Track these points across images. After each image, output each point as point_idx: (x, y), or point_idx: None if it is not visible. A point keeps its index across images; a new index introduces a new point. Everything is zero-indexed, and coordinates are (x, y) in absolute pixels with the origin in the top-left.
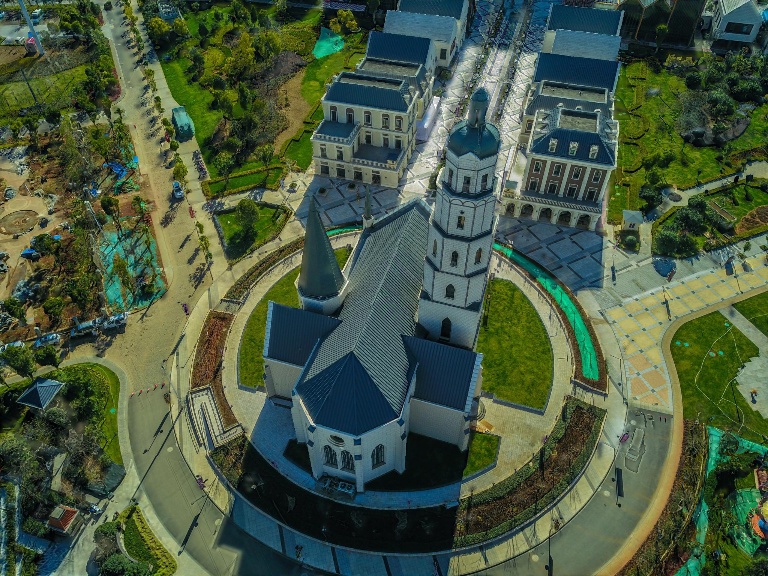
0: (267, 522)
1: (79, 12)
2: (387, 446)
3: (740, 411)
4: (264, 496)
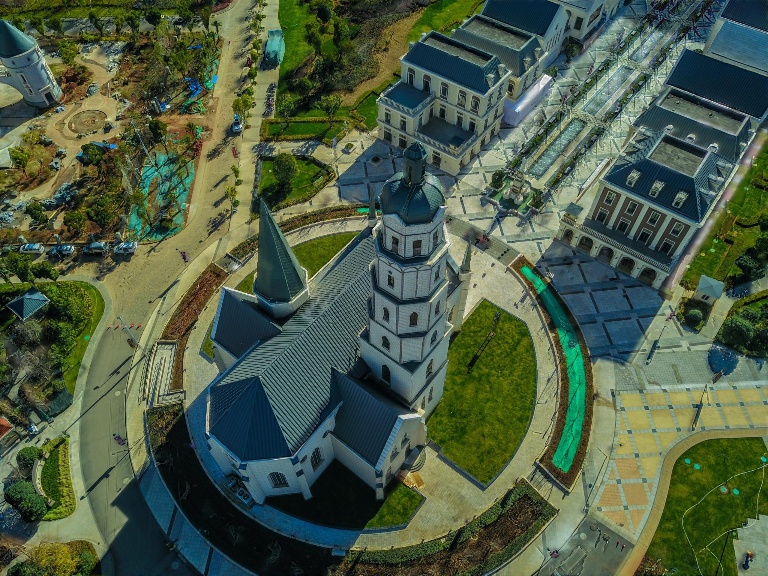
0: (167, 498)
1: None
2: (285, 474)
3: (721, 571)
4: (173, 472)
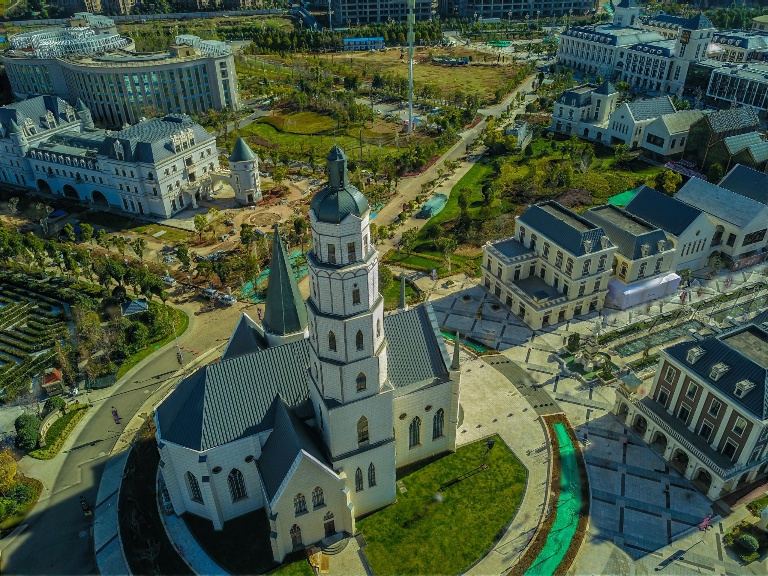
0: (118, 480)
1: (461, 116)
2: (199, 481)
3: None
4: (136, 461)
